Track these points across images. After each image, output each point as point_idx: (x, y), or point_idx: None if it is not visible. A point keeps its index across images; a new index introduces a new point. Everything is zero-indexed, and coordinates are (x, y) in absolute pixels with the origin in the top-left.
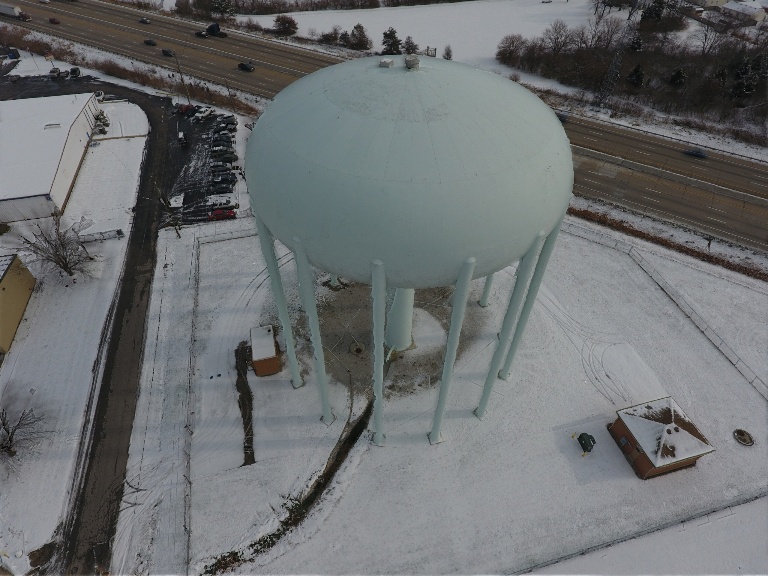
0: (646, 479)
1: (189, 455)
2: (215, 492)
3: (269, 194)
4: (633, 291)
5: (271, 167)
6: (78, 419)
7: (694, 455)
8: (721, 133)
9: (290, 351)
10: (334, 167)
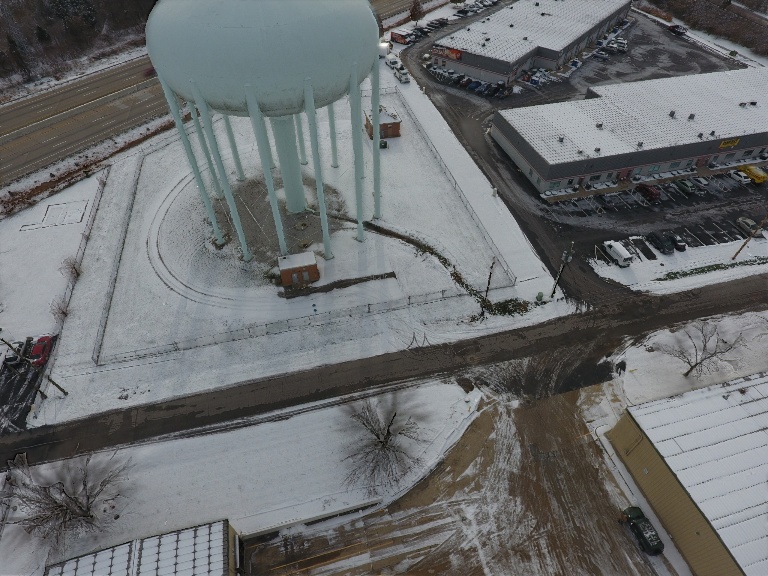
0: (400, 135)
1: (388, 310)
2: (415, 289)
3: (328, 51)
4: None
5: (315, 36)
6: (348, 408)
7: (395, 111)
8: (127, 48)
9: (326, 220)
10: (339, 8)
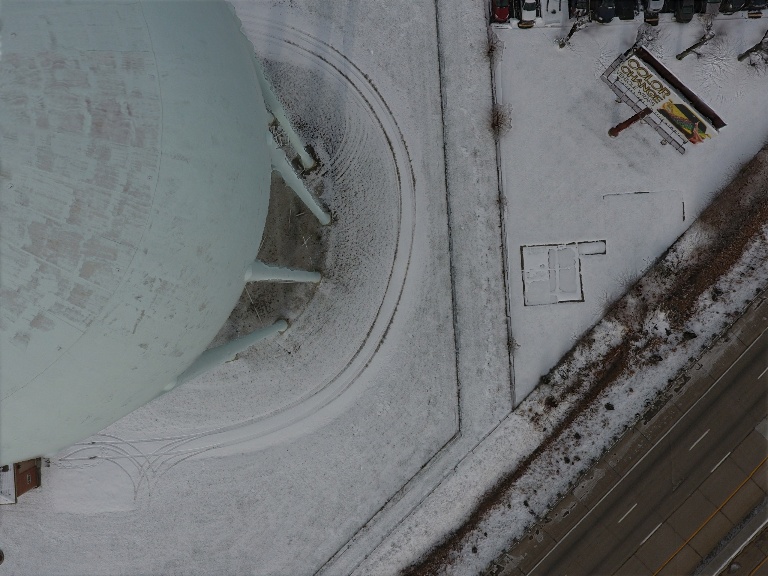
0: None
1: None
2: None
3: None
4: (211, 568)
5: None
6: None
7: None
8: None
9: None
10: None
